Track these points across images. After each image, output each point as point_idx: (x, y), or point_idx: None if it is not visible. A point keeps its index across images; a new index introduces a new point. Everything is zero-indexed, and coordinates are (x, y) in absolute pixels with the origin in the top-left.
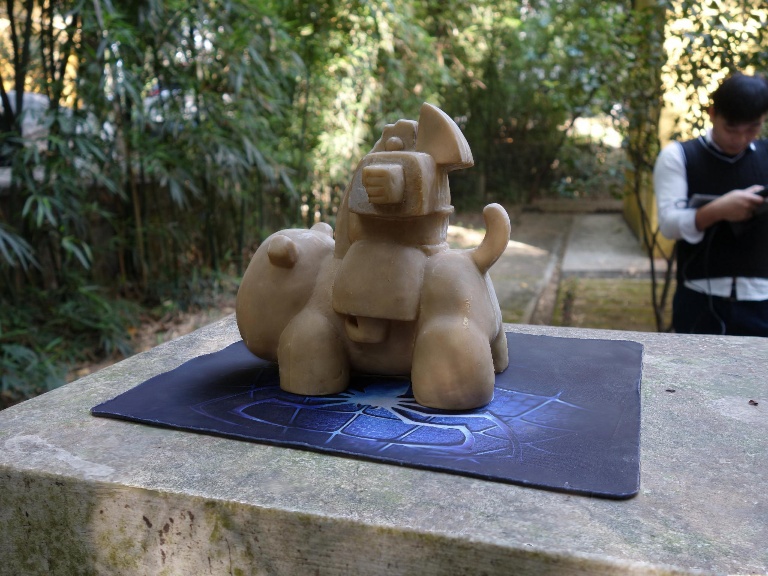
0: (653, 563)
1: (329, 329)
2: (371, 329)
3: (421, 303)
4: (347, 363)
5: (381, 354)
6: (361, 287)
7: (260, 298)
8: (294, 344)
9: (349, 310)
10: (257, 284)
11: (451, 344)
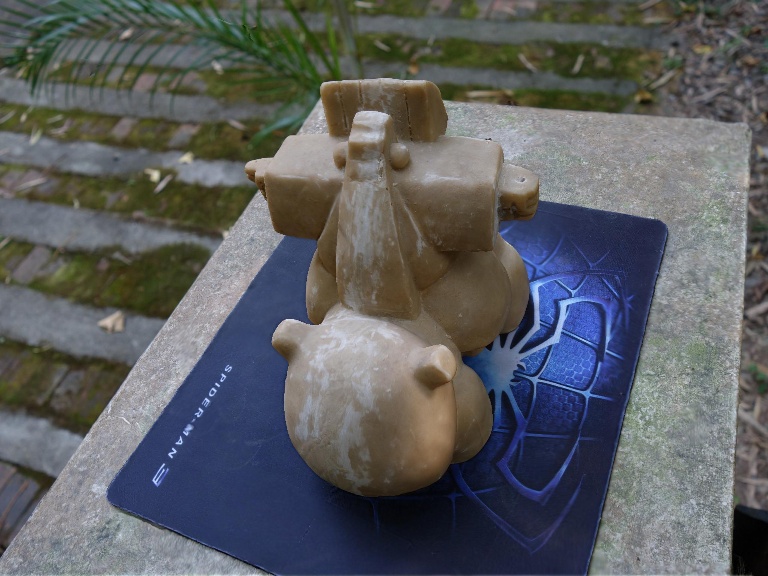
0: (743, 231)
1: None
2: None
3: None
4: None
5: None
6: None
7: (447, 427)
8: (478, 414)
9: None
10: (438, 422)
11: (523, 267)
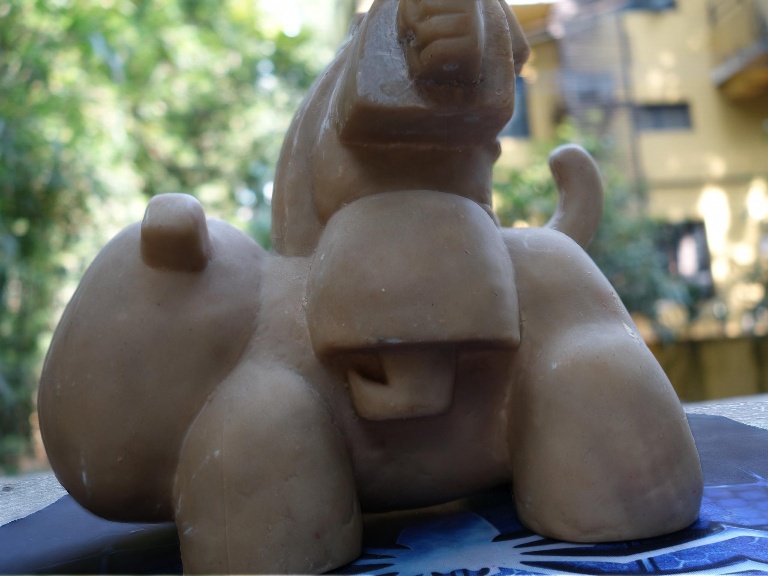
0: None
1: (314, 400)
2: (426, 380)
3: (521, 309)
4: (355, 484)
5: (430, 448)
6: (406, 273)
7: (123, 349)
8: (232, 449)
9: (382, 332)
10: (111, 317)
11: (630, 377)
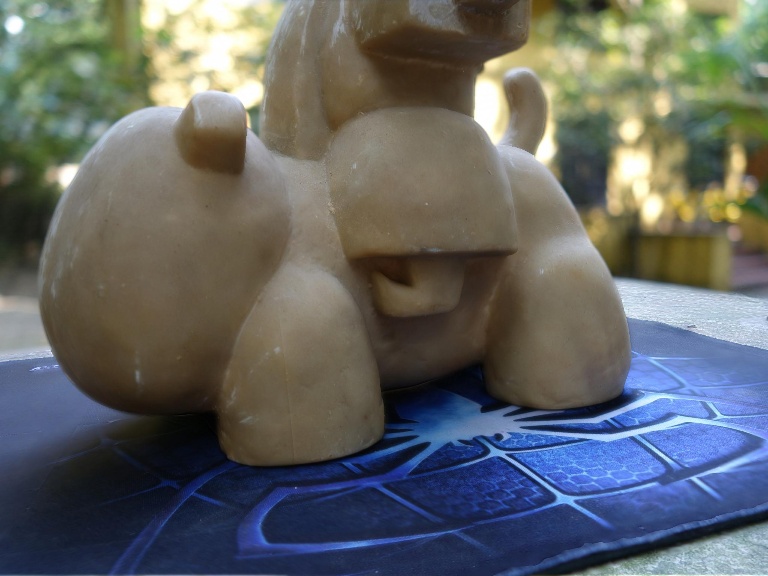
0: None
1: (352, 300)
2: (446, 282)
3: None
4: None
5: (430, 339)
6: (445, 189)
7: (177, 251)
8: (292, 346)
9: (425, 242)
10: (160, 217)
11: (598, 282)
